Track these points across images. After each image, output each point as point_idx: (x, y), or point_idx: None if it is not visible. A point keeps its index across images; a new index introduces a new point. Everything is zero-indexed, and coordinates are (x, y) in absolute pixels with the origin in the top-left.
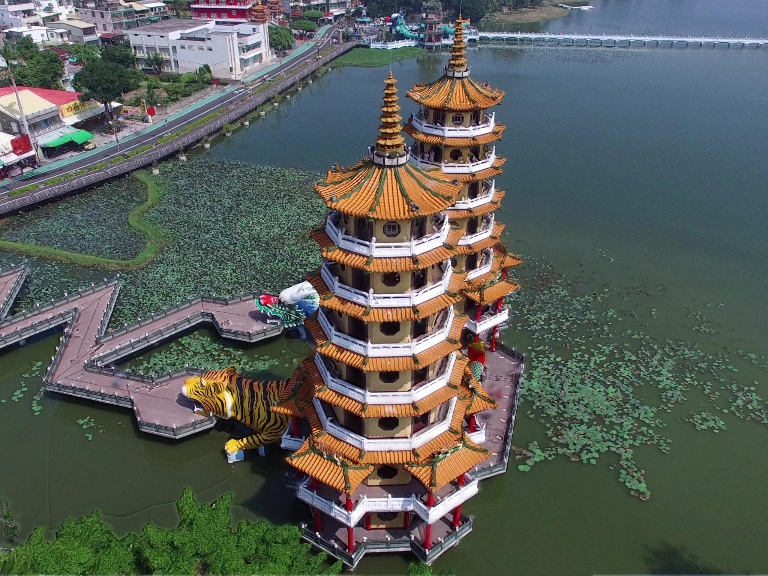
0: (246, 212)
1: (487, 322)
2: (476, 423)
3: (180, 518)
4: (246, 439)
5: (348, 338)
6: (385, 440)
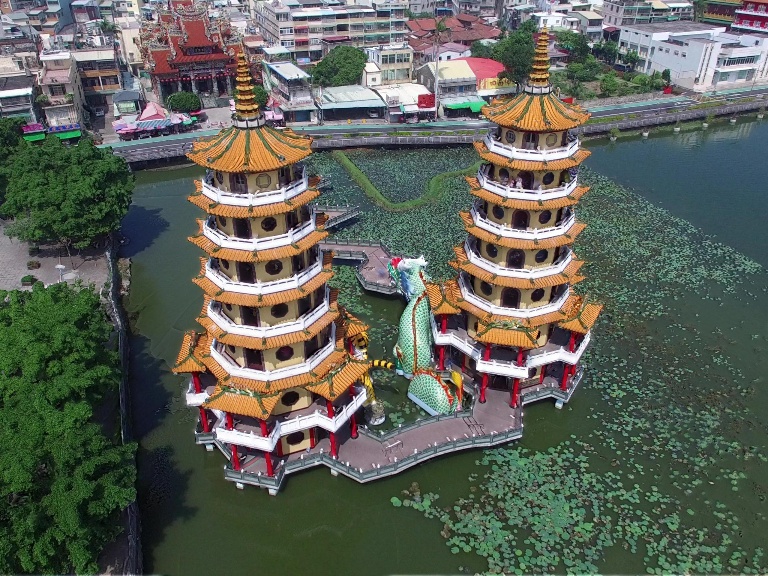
0: None
1: (494, 365)
2: (340, 413)
3: None
4: None
5: None
6: (220, 355)
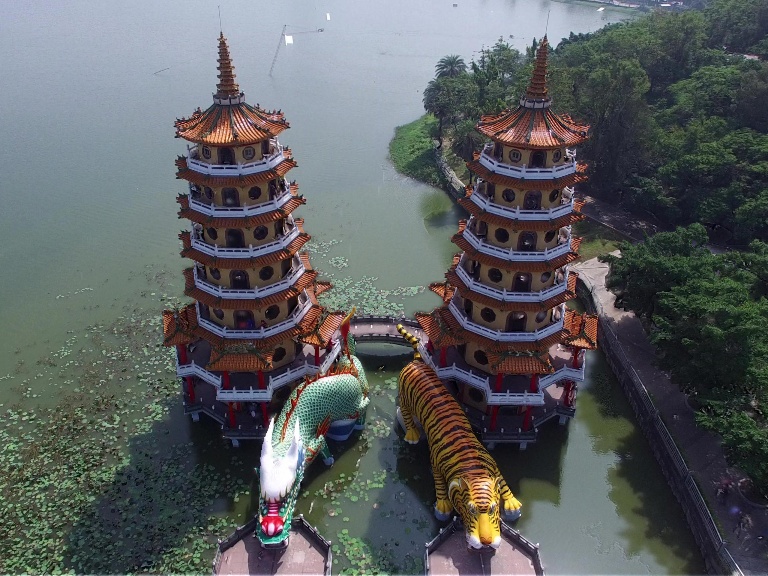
0: None
1: None
2: None
3: None
4: (506, 487)
5: None
6: None
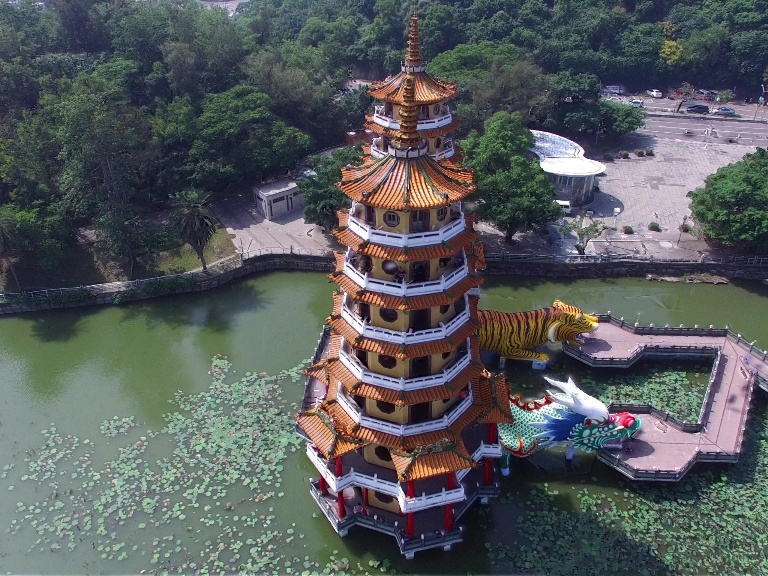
0: None
1: None
2: None
3: None
4: None
5: None
6: None
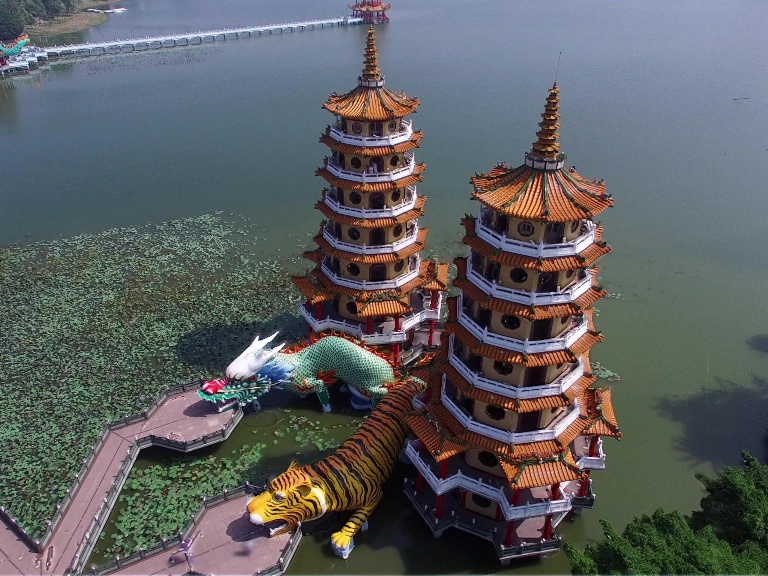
0: (8, 317)
1: (439, 306)
2: None
3: (586, 573)
4: (352, 523)
5: (545, 341)
6: (565, 420)
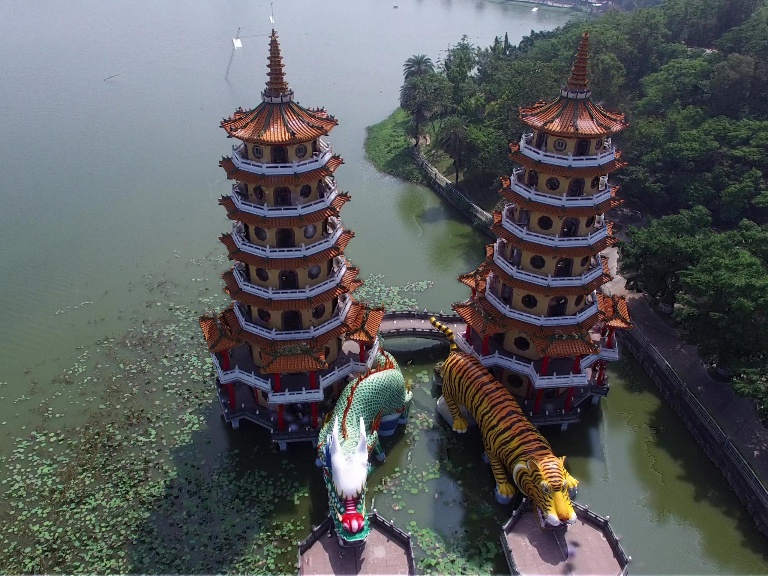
0: None
1: None
2: None
3: None
4: None
5: None
6: None
